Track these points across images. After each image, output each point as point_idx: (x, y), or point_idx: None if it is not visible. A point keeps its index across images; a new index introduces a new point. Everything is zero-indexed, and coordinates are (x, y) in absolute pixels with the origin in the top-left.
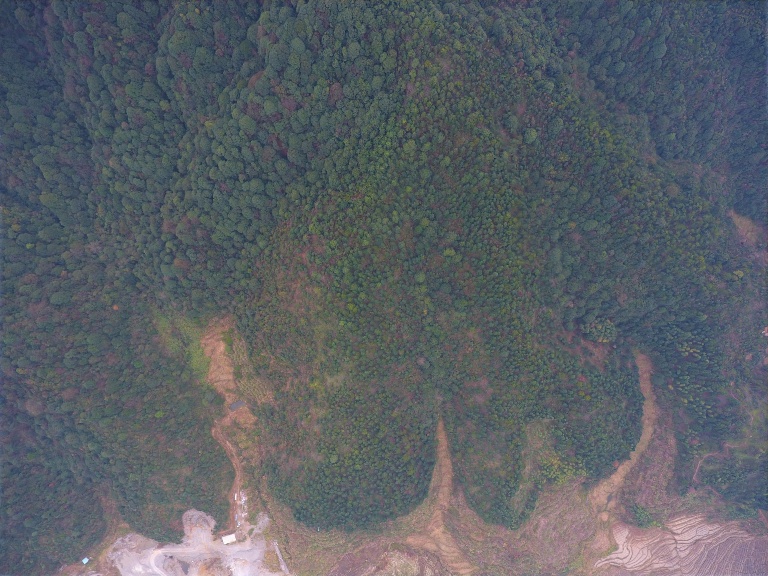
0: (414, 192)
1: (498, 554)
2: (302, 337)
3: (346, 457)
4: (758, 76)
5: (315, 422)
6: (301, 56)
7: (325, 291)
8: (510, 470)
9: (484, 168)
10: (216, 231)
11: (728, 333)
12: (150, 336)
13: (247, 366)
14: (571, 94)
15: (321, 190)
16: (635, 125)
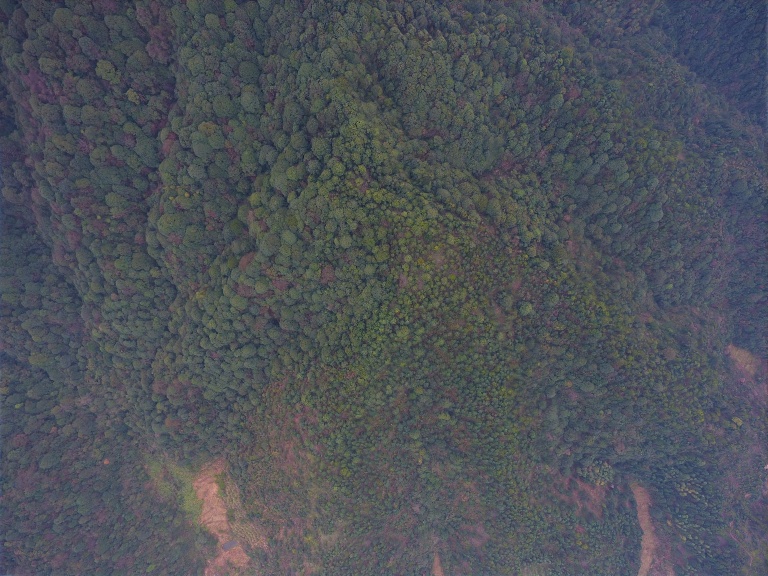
0: (408, 364)
1: None
2: (295, 495)
3: None
4: (756, 222)
5: None
6: (292, 247)
7: (318, 460)
8: None
9: (479, 350)
10: (208, 390)
11: (727, 477)
12: (142, 483)
13: (240, 512)
14: (567, 267)
15: (314, 361)
16: (632, 286)
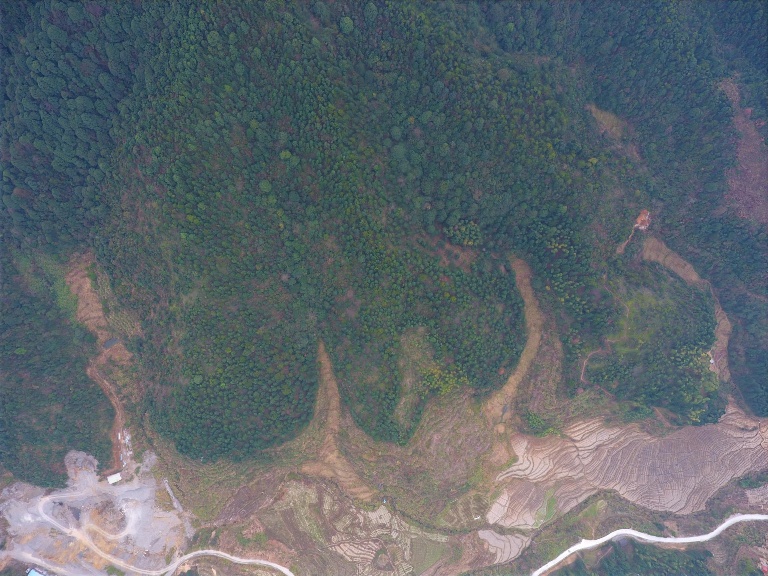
0: (236, 92)
1: (393, 473)
2: (152, 257)
3: (210, 376)
4: None
5: (176, 344)
6: None
7: (160, 202)
8: (388, 382)
9: (295, 57)
10: (54, 157)
11: (592, 224)
12: (9, 276)
13: (112, 299)
14: None
15: (144, 99)
16: (462, 12)
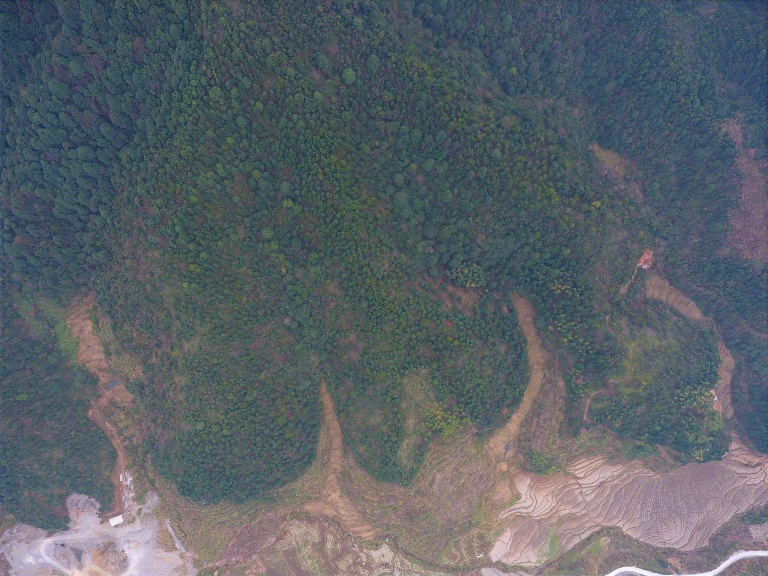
0: (238, 144)
1: (396, 513)
2: (153, 304)
3: (212, 423)
4: (597, 4)
5: (178, 390)
6: (92, 10)
7: (162, 253)
8: (390, 424)
9: (297, 110)
10: (56, 204)
11: (595, 266)
12: (10, 320)
13: (113, 342)
14: (385, 30)
15: (145, 150)
16: (465, 60)
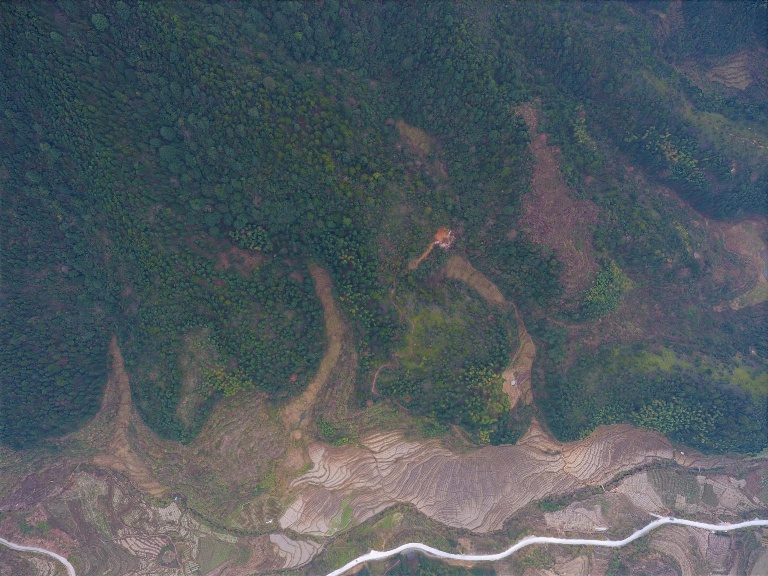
0: None
1: (181, 472)
2: None
3: None
4: None
5: None
6: None
7: None
8: (166, 380)
9: (34, 49)
10: None
11: (378, 238)
12: None
13: None
14: None
15: None
16: (234, 17)
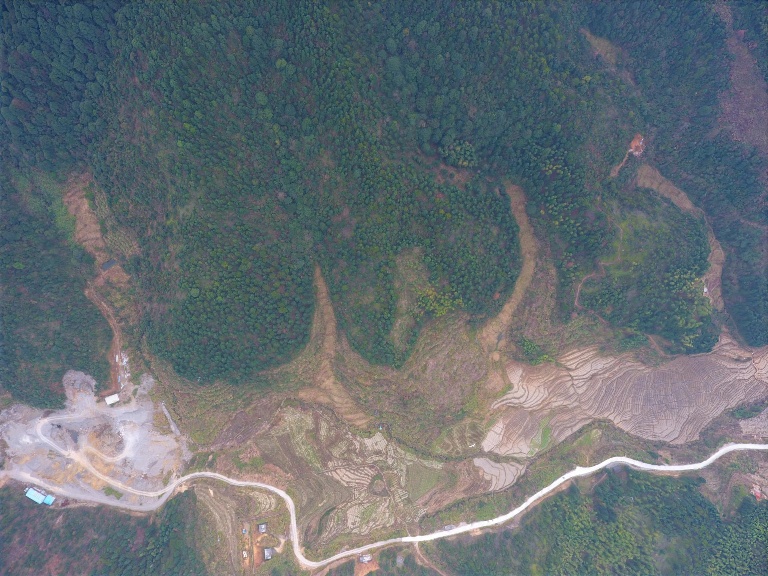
0: None
1: (389, 398)
2: (149, 169)
3: (207, 290)
4: None
5: (173, 258)
6: None
7: (157, 108)
8: (383, 301)
9: None
10: (52, 69)
11: (586, 144)
12: (8, 194)
13: (109, 217)
14: None
15: (140, 4)
16: None
